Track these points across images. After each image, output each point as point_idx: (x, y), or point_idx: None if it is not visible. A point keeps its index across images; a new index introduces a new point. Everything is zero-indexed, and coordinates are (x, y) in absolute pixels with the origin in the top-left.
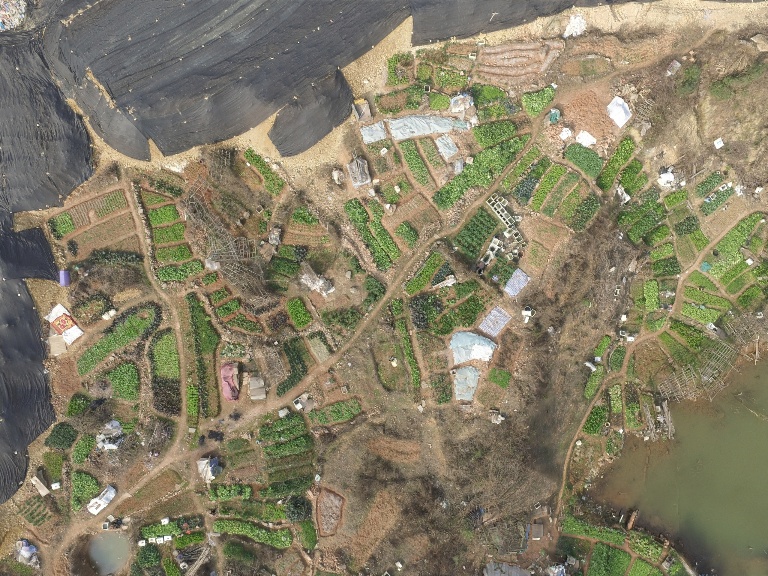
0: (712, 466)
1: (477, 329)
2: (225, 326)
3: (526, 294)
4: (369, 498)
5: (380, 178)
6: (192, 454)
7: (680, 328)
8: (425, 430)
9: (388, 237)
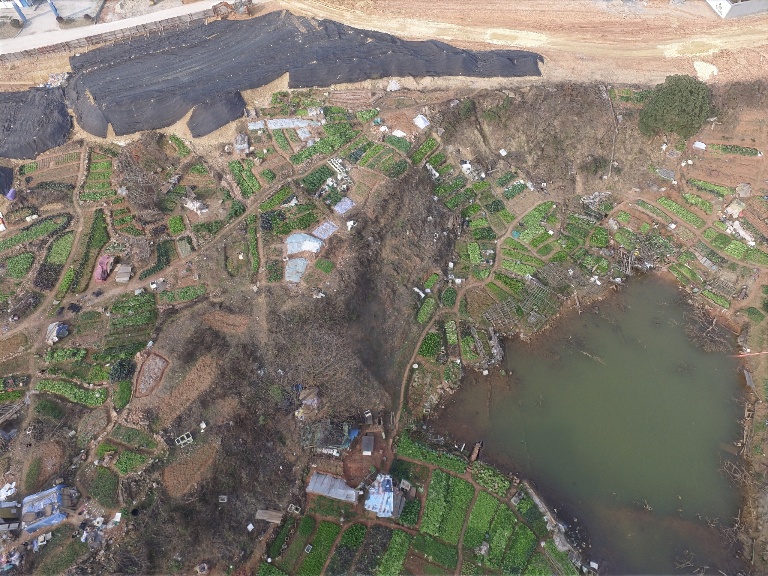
0: (556, 404)
1: (310, 233)
2: (117, 232)
3: (351, 213)
4: (192, 362)
5: (255, 146)
6: (47, 322)
7: (503, 279)
8: (256, 306)
9: (254, 178)
